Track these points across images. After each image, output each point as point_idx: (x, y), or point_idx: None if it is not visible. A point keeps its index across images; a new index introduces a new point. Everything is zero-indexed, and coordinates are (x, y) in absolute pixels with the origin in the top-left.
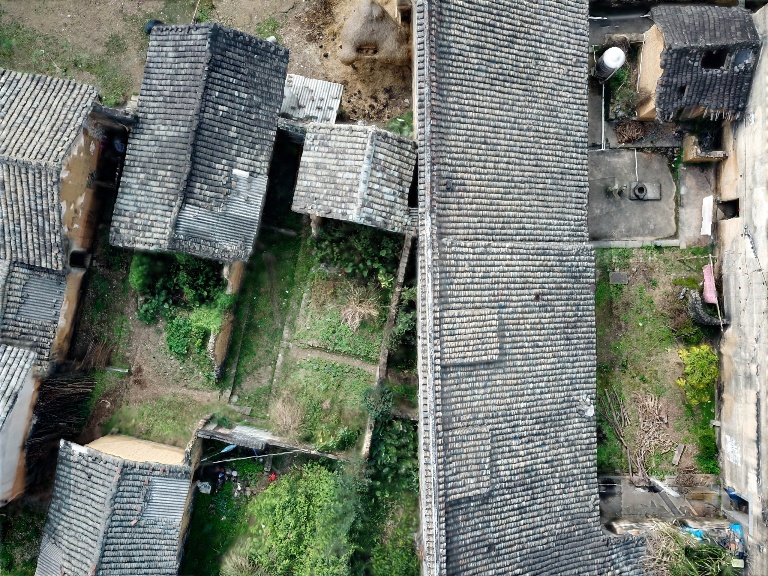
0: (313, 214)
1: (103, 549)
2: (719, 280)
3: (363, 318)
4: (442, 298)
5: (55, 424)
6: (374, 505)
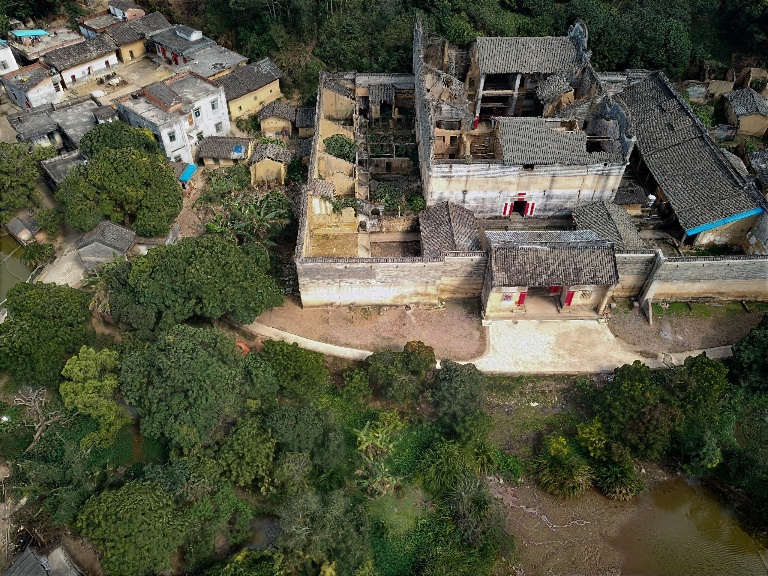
0: None
1: None
2: None
3: None
4: None
5: None
6: None
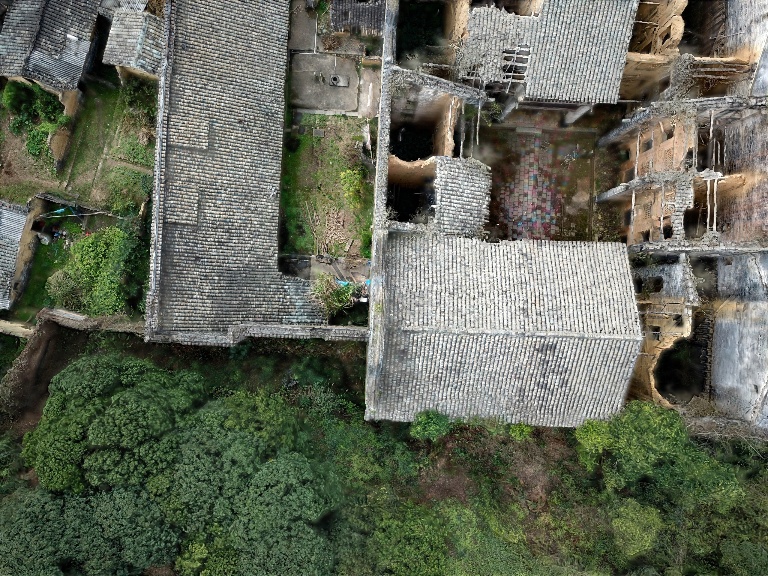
0: (113, 64)
1: None
2: (376, 136)
3: (149, 138)
4: (173, 108)
5: None
6: (148, 254)
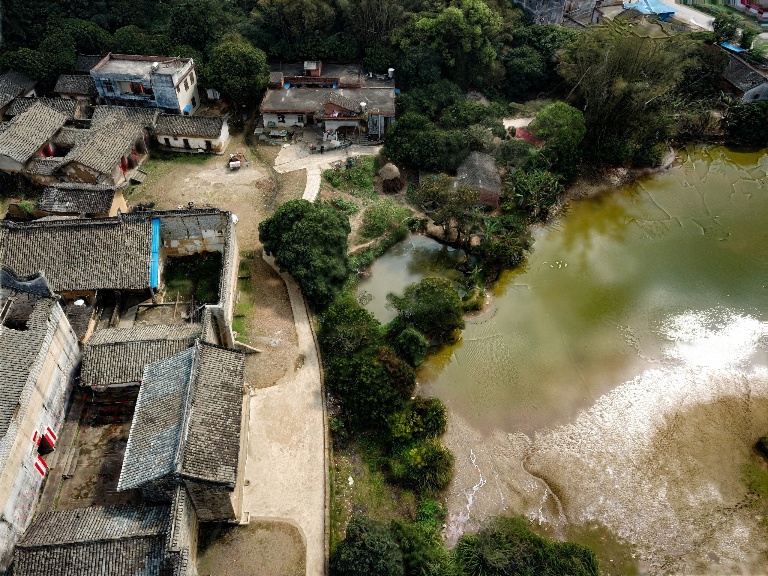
0: None
1: None
2: None
3: None
4: None
5: (9, 181)
6: None
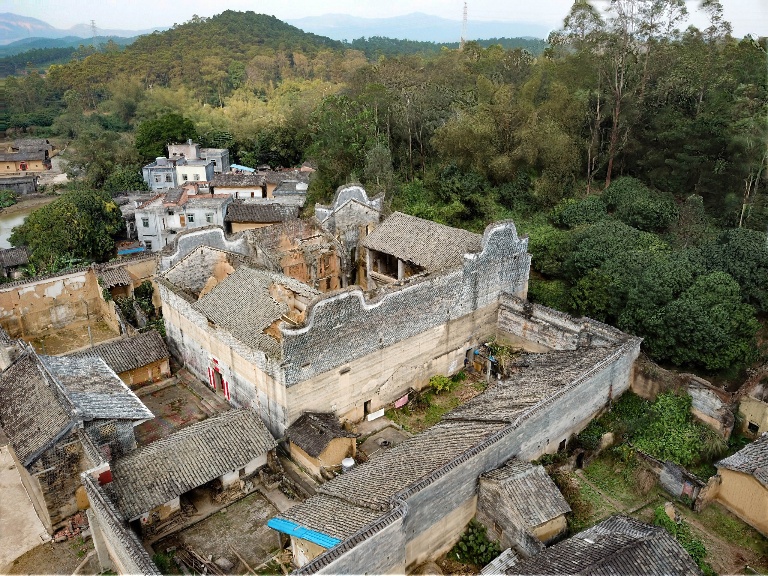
0: None
1: None
2: None
3: None
4: None
5: None
6: None
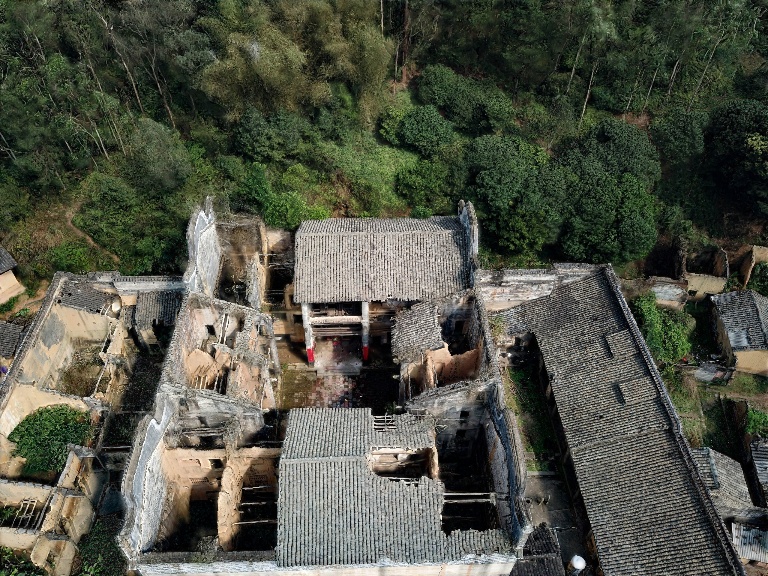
0: None
1: (759, 318)
2: None
3: None
4: (659, 403)
5: None
6: None
